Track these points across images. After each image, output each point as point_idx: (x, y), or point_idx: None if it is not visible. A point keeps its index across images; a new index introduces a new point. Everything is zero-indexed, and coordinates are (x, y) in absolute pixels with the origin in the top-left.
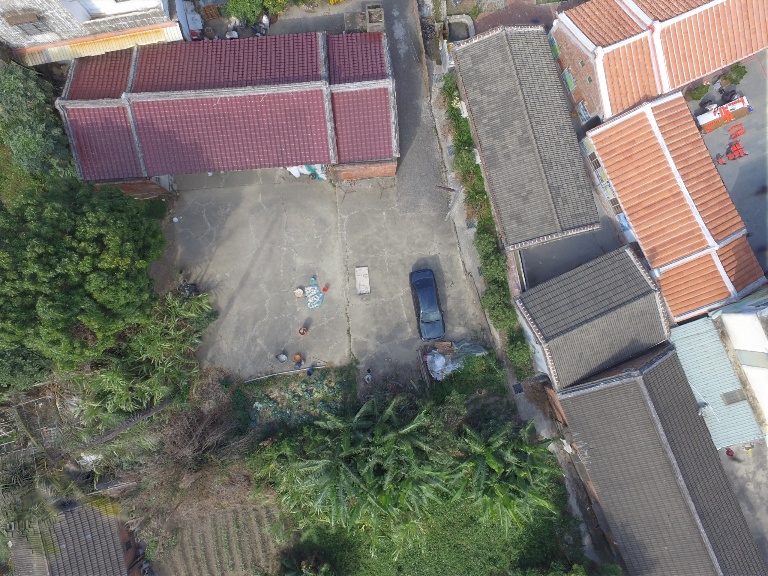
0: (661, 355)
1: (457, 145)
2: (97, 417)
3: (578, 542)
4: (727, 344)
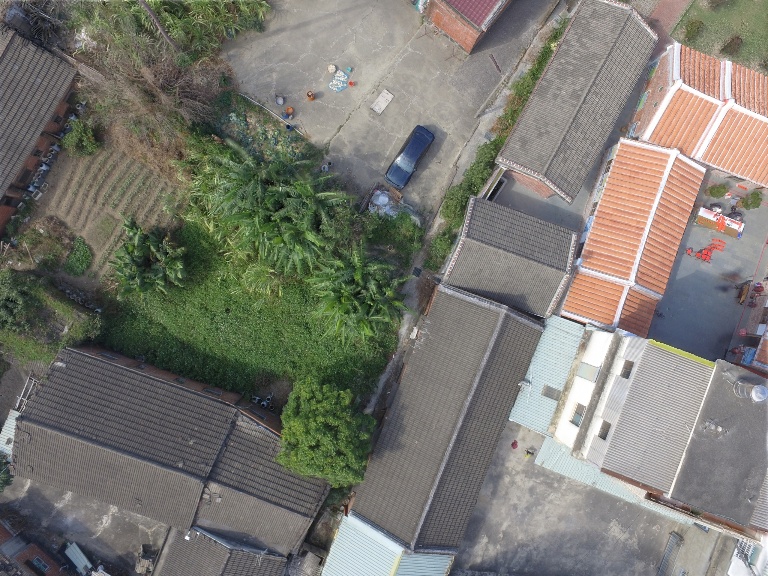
0: (531, 320)
1: (529, 75)
2: (119, 7)
3: (361, 407)
4: (580, 354)
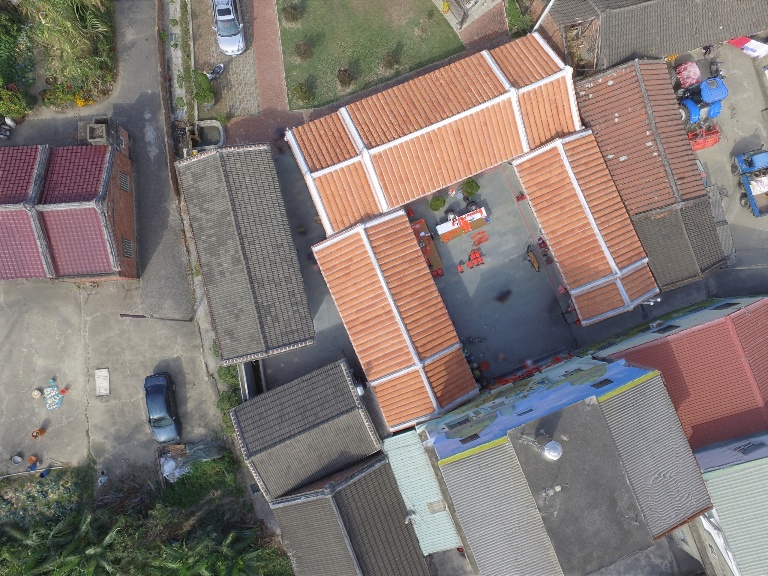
0: (367, 468)
1: None
2: None
3: None
4: None
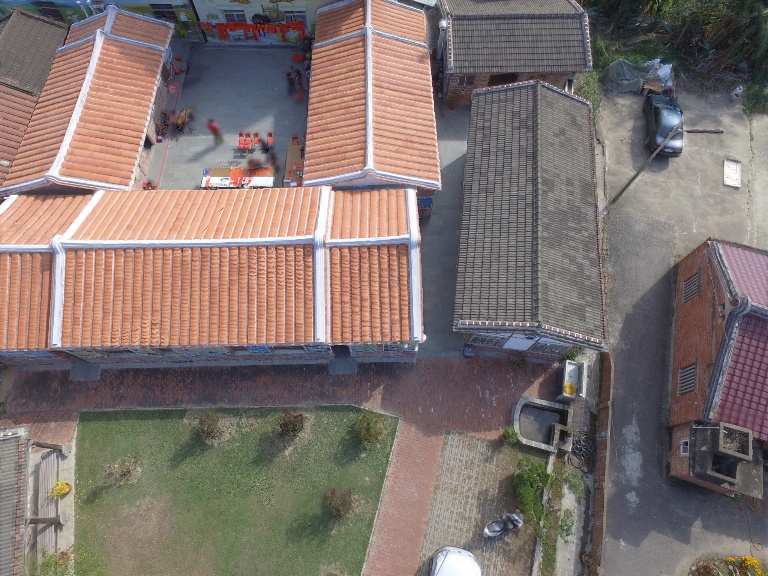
0: None
1: None
2: None
3: None
4: None
